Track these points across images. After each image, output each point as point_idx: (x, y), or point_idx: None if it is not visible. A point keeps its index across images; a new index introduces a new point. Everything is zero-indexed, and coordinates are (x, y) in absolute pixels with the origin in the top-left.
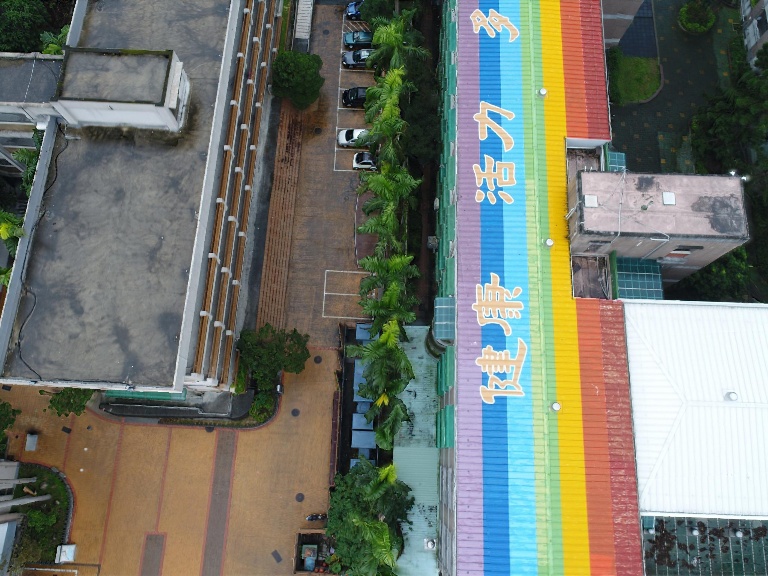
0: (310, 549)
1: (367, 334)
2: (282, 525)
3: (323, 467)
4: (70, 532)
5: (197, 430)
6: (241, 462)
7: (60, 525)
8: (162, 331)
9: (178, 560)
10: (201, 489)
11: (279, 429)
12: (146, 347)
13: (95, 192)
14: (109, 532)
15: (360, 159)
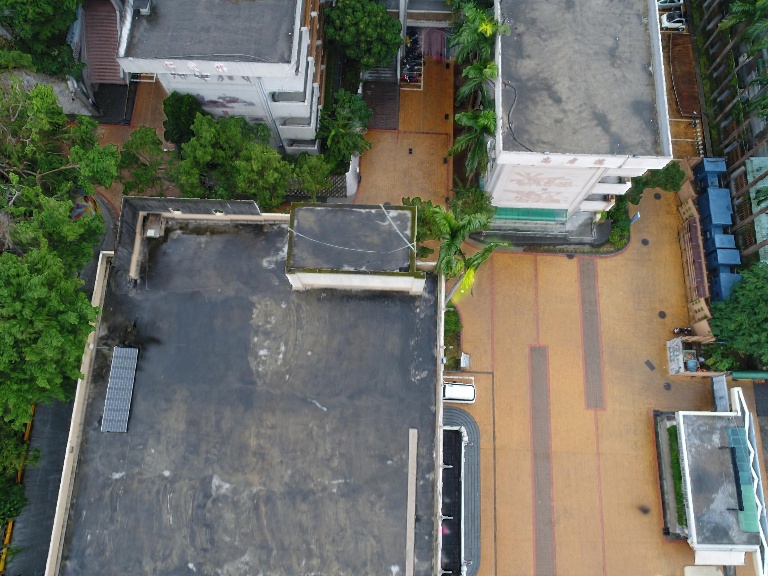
0: (690, 353)
1: (714, 166)
2: (650, 338)
3: (679, 289)
4: (461, 345)
5: (559, 257)
6: (604, 285)
7: (454, 337)
8: (637, 116)
9: (562, 368)
10: (572, 308)
11: (633, 256)
12: (626, 129)
13: (546, 1)
14: (496, 345)
15: (671, 18)
